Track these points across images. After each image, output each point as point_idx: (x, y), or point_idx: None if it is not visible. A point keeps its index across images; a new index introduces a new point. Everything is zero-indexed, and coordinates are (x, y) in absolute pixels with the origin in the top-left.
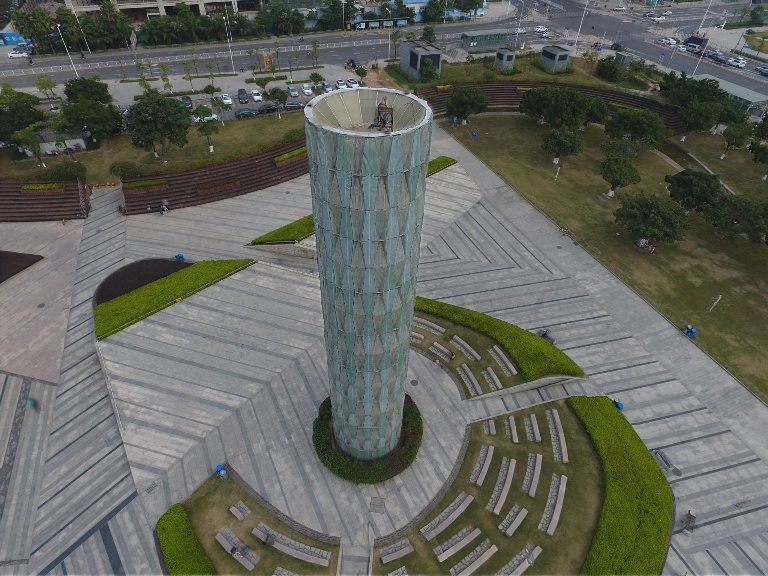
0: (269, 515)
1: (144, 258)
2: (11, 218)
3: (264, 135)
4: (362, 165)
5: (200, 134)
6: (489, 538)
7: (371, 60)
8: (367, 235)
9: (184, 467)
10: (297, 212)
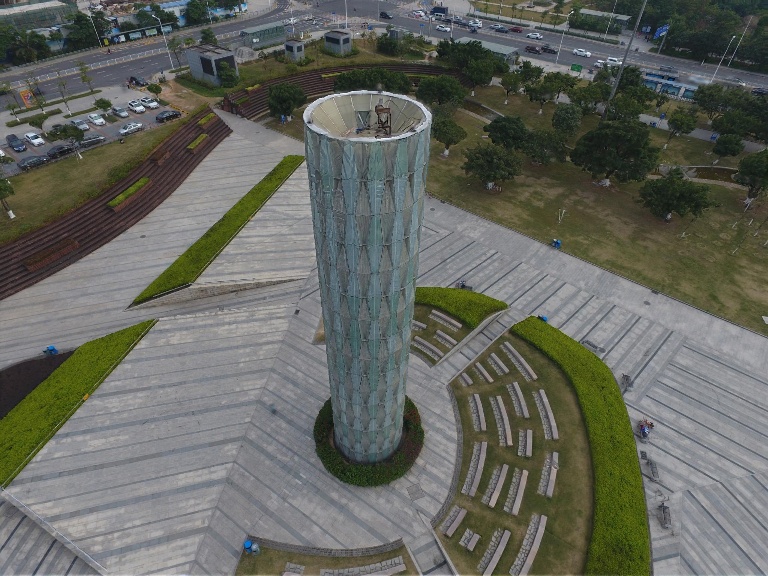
0: (324, 559)
1: None
2: None
3: (73, 182)
4: (395, 168)
5: None
6: (517, 467)
7: (154, 74)
8: (394, 236)
9: (204, 567)
10: (167, 254)
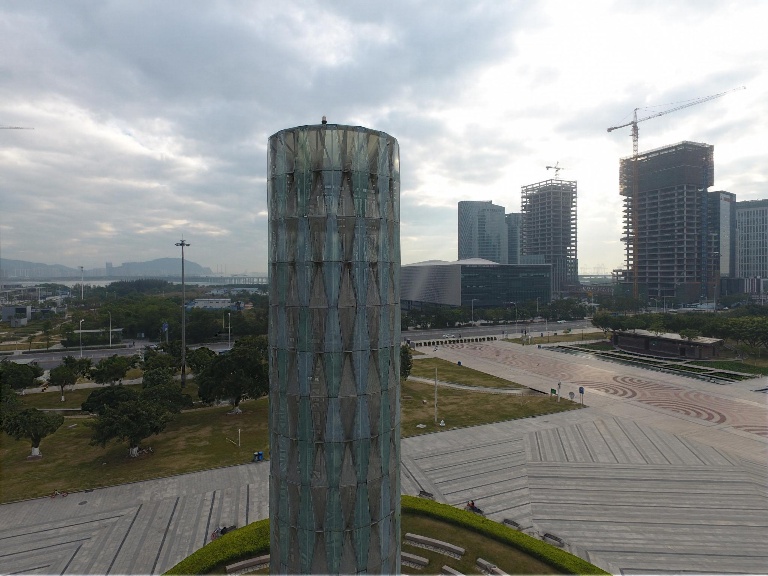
0: None
1: None
2: None
3: None
4: None
5: None
6: None
7: None
8: None
9: None
10: None
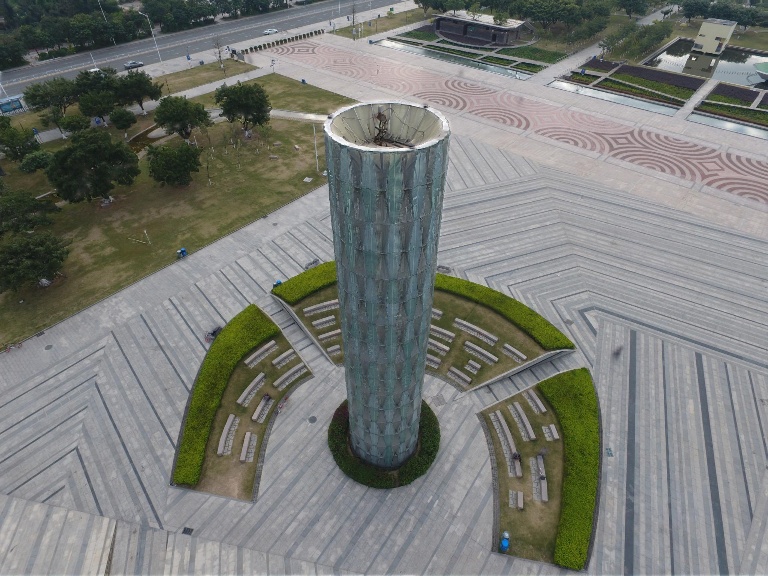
0: (500, 475)
1: None
2: None
3: None
4: None
5: None
6: None
7: None
8: None
9: None
10: None
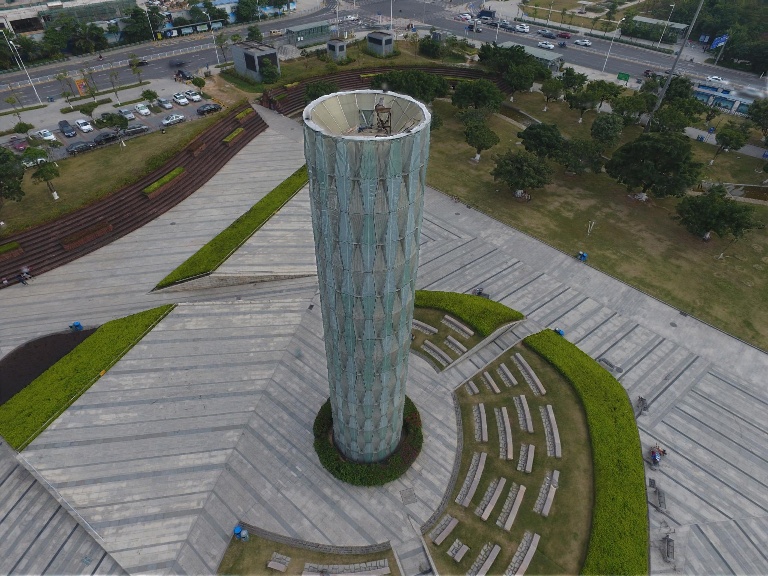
0: (310, 553)
1: (27, 340)
2: None
3: (114, 168)
4: (388, 168)
5: (36, 181)
6: (514, 482)
7: (200, 68)
8: (388, 236)
9: (194, 547)
10: (193, 242)
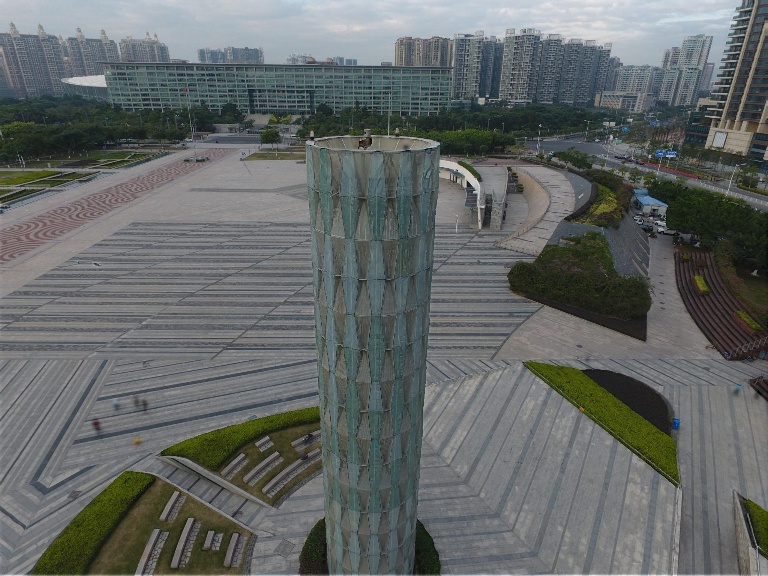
0: None
1: (668, 399)
2: (699, 321)
3: None
4: None
5: None
6: None
7: None
8: None
9: None
10: None
